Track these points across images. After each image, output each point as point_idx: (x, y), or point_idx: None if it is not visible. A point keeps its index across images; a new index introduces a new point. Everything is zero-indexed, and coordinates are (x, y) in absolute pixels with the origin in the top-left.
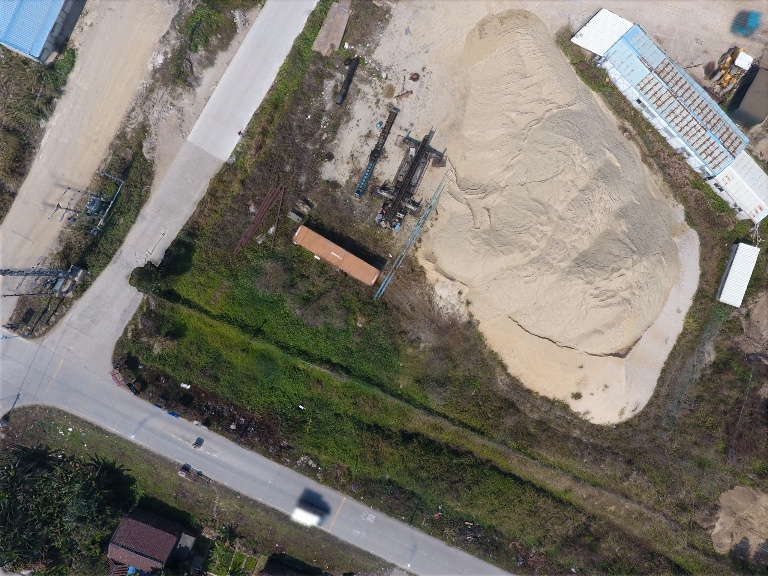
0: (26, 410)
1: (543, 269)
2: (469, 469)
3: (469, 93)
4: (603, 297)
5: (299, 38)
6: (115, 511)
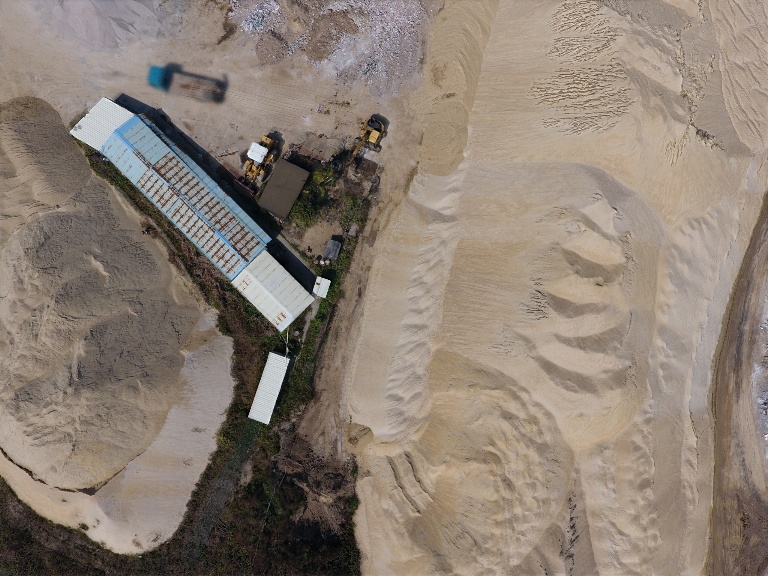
0: None
1: None
2: None
3: None
4: (37, 435)
5: None
6: None
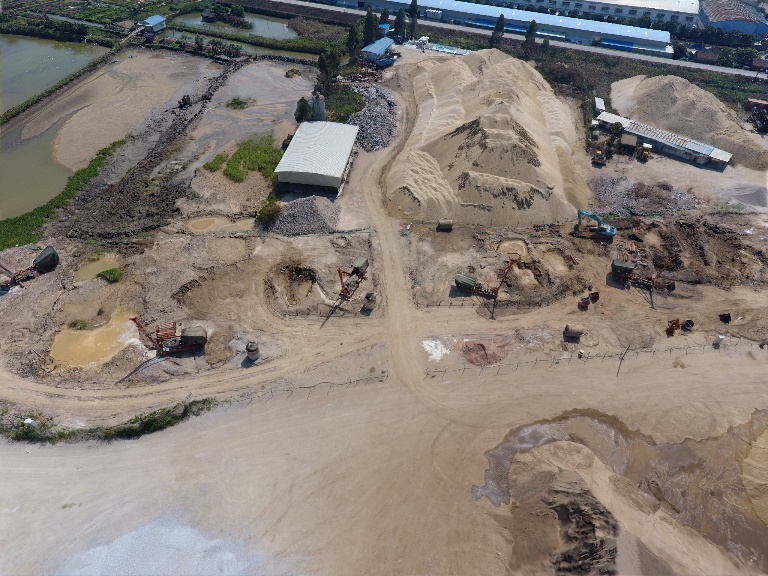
0: None
1: None
2: None
3: None
4: None
5: None
6: None
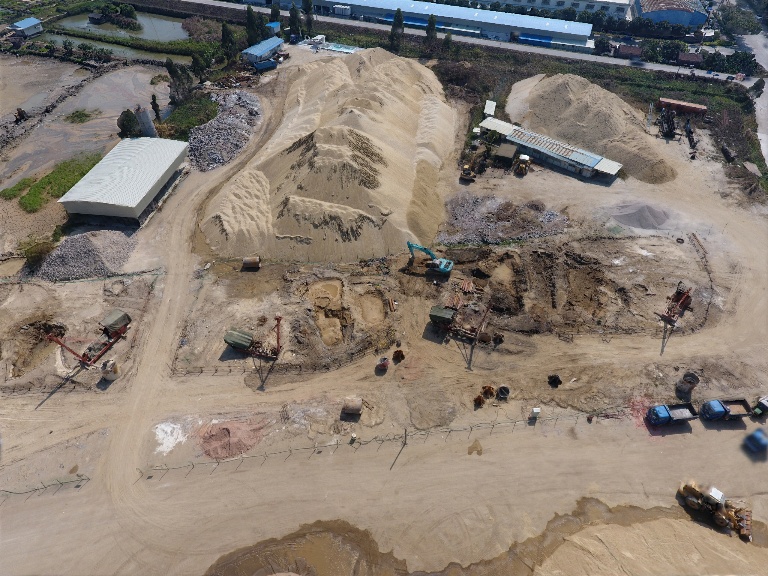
0: (765, 77)
1: (599, 86)
2: (578, 73)
3: (660, 155)
4: (573, 75)
5: (766, 165)
6: (707, 63)
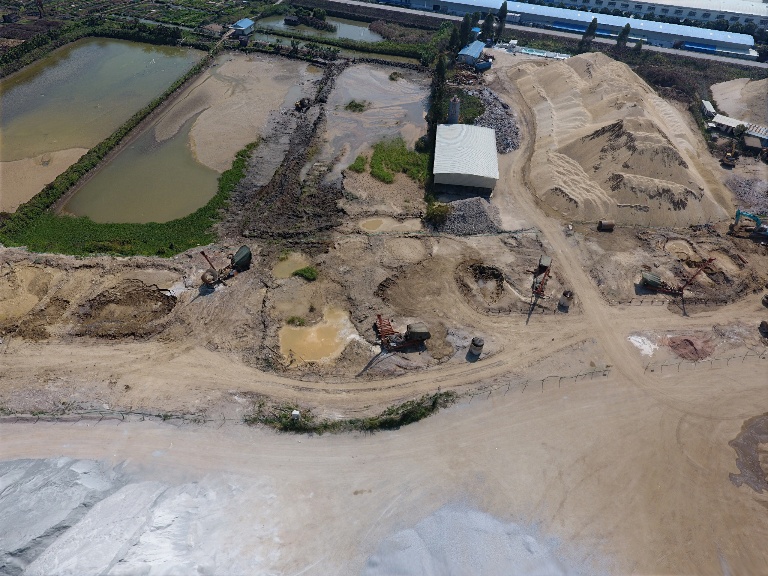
0: None
1: None
2: (758, 79)
3: None
4: None
5: None
6: None
